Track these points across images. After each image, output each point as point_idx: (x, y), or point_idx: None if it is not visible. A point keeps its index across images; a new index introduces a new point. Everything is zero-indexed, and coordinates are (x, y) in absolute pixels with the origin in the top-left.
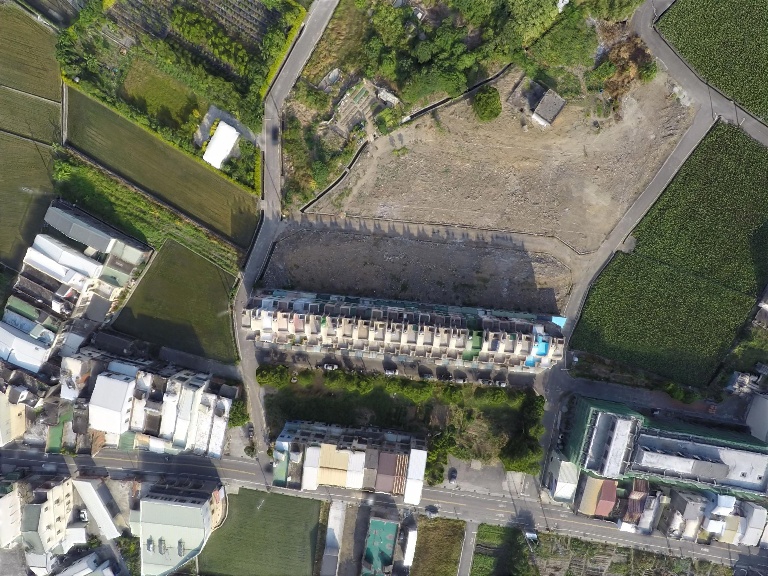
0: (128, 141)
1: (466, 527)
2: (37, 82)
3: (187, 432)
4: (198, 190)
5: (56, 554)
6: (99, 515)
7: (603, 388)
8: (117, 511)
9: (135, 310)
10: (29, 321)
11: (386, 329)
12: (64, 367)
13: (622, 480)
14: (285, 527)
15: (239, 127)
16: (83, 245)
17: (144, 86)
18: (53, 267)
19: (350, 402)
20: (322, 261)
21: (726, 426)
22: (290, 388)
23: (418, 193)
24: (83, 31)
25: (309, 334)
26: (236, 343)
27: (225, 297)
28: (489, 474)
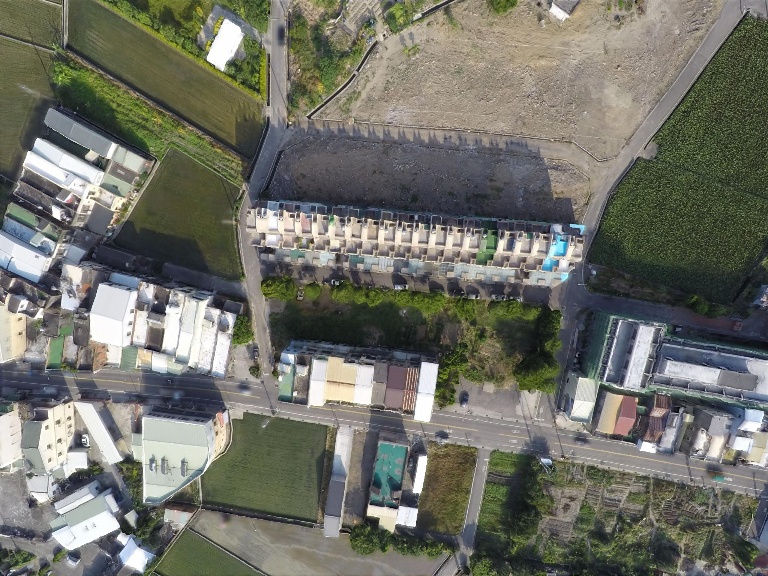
0: (130, 45)
1: (478, 454)
2: None
3: (190, 346)
4: (202, 96)
5: (58, 481)
6: (101, 438)
7: (622, 304)
8: (119, 436)
9: (137, 224)
10: (29, 230)
11: (396, 228)
12: (64, 275)
13: (643, 397)
14: (291, 454)
15: (244, 28)
16: (84, 151)
17: None
18: (53, 172)
19: (358, 320)
20: (329, 170)
21: (752, 344)
22: (296, 306)
23: (429, 96)
24: None
25: (316, 235)
26: (241, 259)
27: (229, 210)
28: (502, 397)
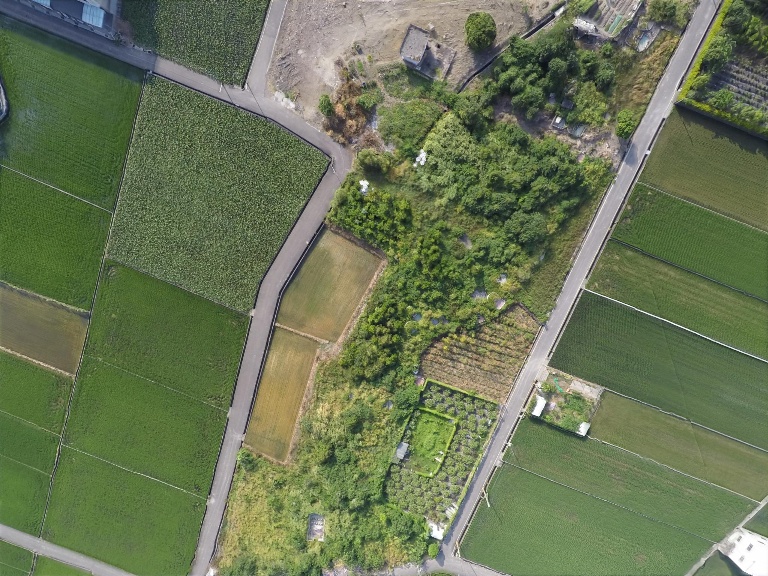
0: None
1: None
2: None
3: None
4: None
5: None
6: None
7: None
8: None
9: None
10: None
11: None
12: None
13: None
14: None
15: None
16: None
17: None
18: None
19: None
20: None
21: None
22: None
23: None
24: None
25: None
26: None
27: None
28: None
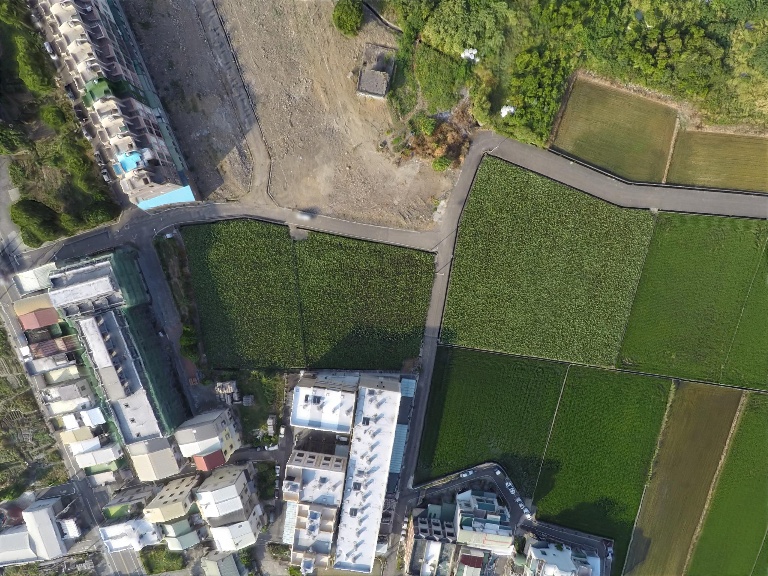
0: None
1: None
2: None
3: None
4: None
5: None
6: None
7: (159, 278)
8: None
9: None
10: None
11: None
12: None
13: None
14: None
15: None
16: None
17: None
18: None
19: None
20: None
21: (185, 400)
22: None
23: None
24: None
25: None
26: None
27: None
28: None
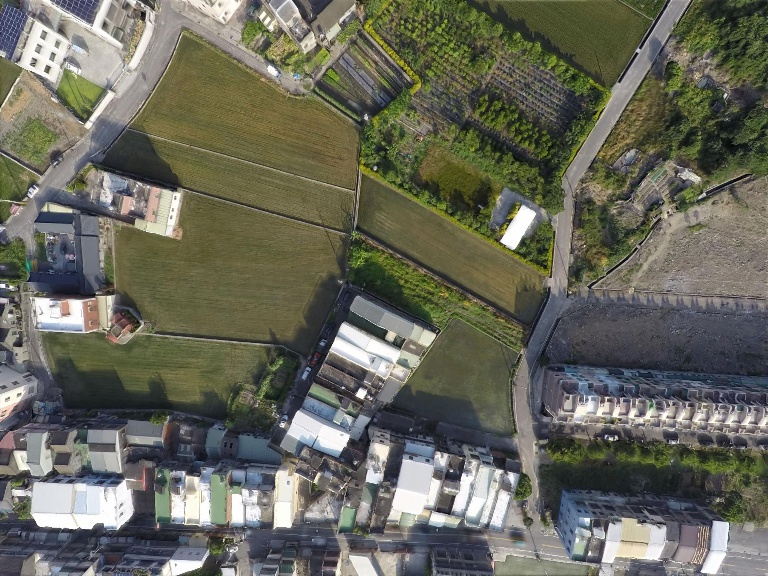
0: (418, 225)
1: None
2: (331, 171)
3: (482, 509)
4: (485, 270)
5: None
6: None
7: None
8: None
9: (414, 388)
10: (328, 407)
11: (713, 411)
12: (372, 453)
13: None
14: None
15: (532, 208)
16: (380, 330)
17: (438, 171)
18: (358, 355)
19: (627, 471)
20: (609, 336)
21: None
22: None
23: (709, 267)
24: (387, 122)
25: (631, 417)
26: (514, 416)
27: (506, 373)
28: (761, 535)
